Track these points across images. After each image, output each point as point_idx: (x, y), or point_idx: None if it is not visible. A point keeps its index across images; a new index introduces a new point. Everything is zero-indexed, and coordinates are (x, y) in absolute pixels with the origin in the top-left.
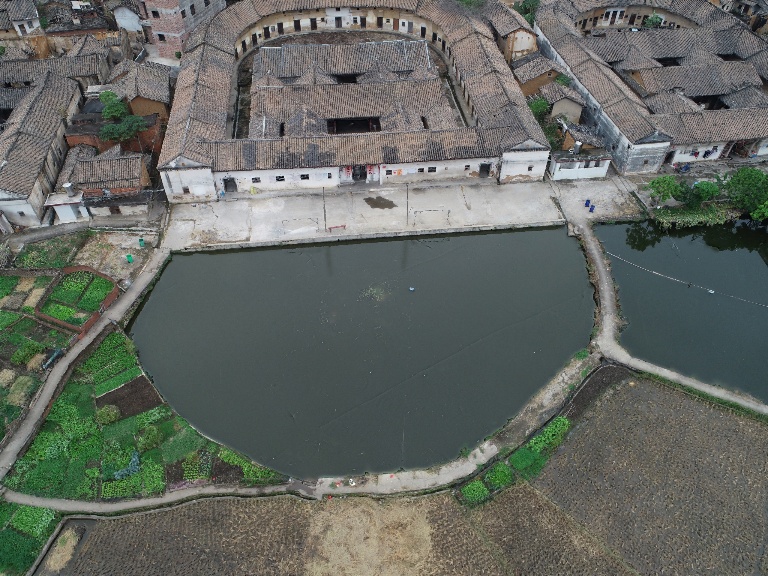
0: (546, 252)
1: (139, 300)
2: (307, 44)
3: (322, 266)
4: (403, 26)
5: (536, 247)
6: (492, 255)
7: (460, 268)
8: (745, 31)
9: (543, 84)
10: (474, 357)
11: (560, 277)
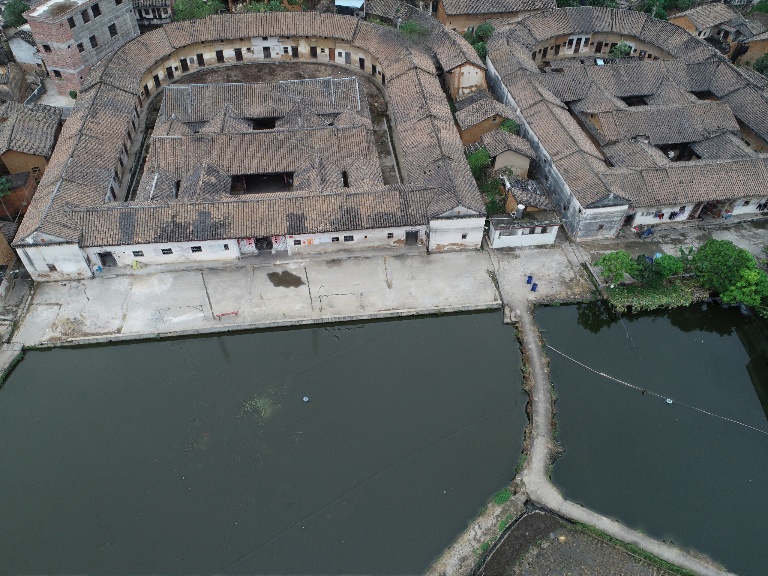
0: (476, 345)
1: None
2: (229, 78)
3: (203, 367)
4: (340, 56)
5: (464, 338)
6: (410, 350)
7: (369, 369)
8: (722, 64)
9: (488, 130)
10: (369, 499)
11: (490, 377)
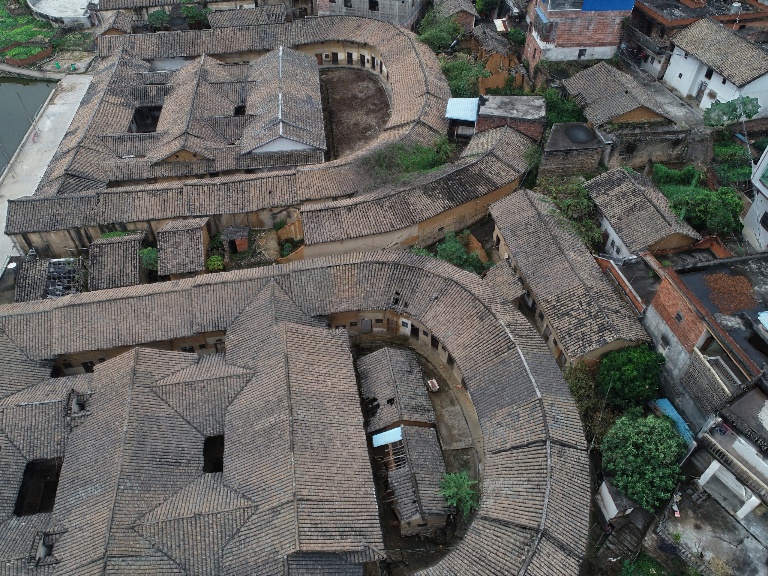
0: None
1: (17, 76)
2: None
3: (0, 137)
4: None
5: None
6: None
7: None
8: None
9: None
10: None
11: None
